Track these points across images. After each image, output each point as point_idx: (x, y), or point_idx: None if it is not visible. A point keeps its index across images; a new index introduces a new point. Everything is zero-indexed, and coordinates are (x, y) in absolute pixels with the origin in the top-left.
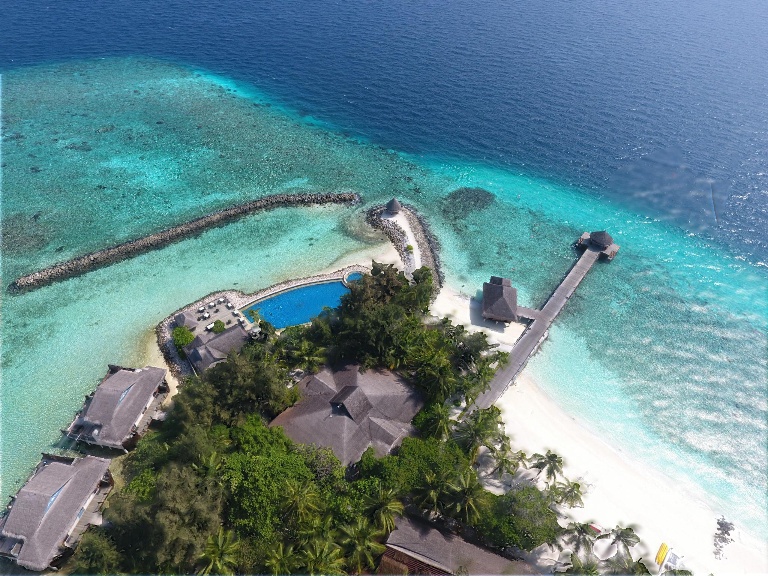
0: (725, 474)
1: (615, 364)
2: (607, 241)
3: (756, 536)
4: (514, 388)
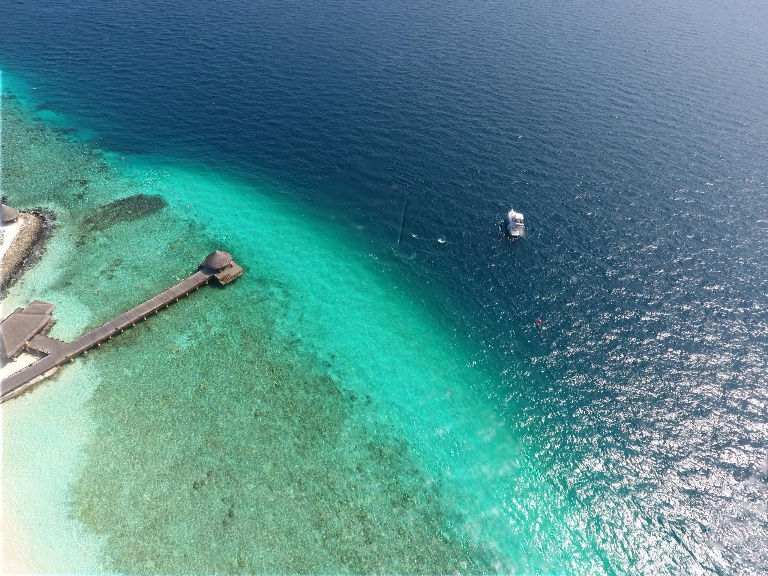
0: (107, 564)
1: (108, 413)
2: (217, 263)
3: None
4: None
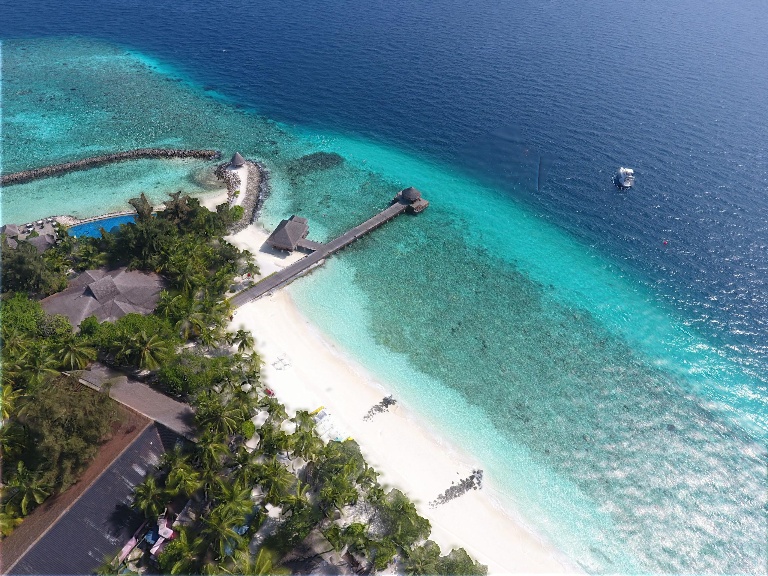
0: (415, 369)
1: (371, 288)
2: (413, 195)
3: (411, 410)
4: (269, 298)
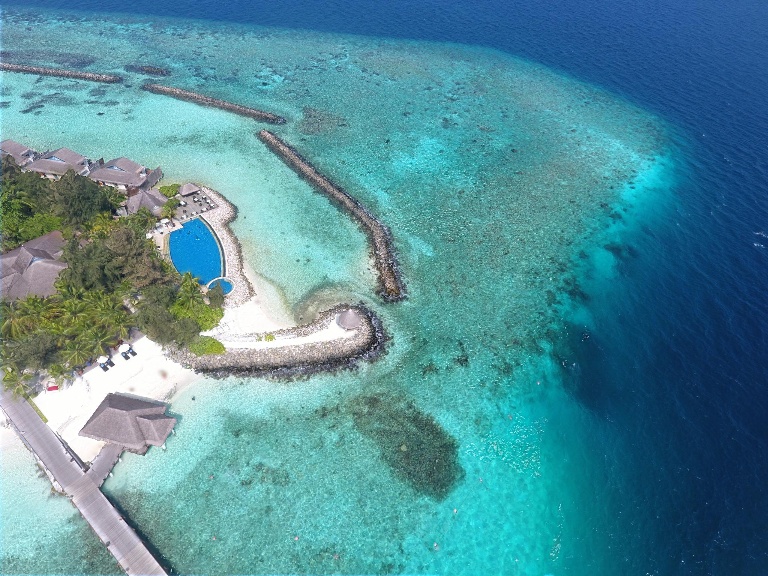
0: None
1: None
2: None
3: None
4: (2, 423)
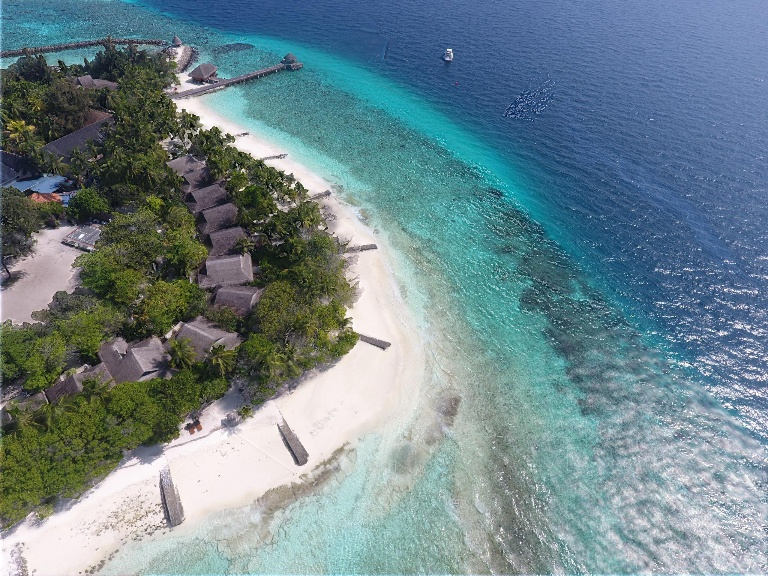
0: None
1: (252, 98)
2: (290, 57)
3: (257, 137)
4: None
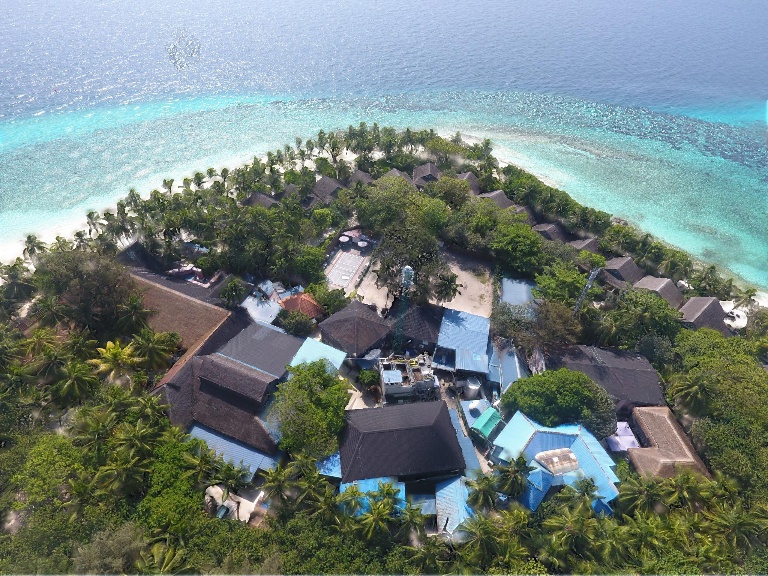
0: (106, 194)
1: (0, 209)
2: None
3: None
4: None
